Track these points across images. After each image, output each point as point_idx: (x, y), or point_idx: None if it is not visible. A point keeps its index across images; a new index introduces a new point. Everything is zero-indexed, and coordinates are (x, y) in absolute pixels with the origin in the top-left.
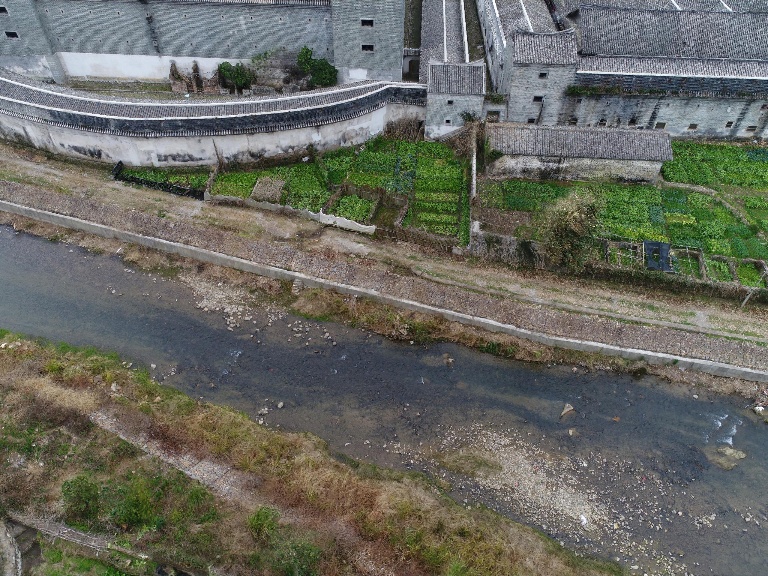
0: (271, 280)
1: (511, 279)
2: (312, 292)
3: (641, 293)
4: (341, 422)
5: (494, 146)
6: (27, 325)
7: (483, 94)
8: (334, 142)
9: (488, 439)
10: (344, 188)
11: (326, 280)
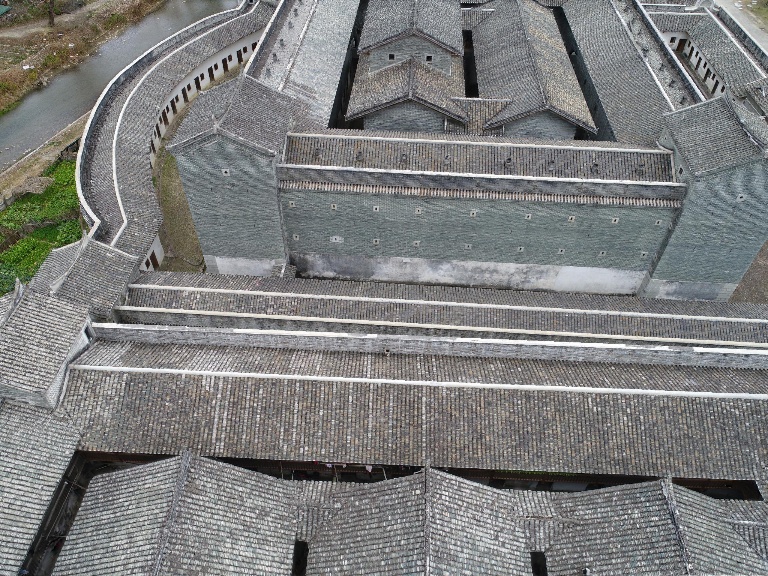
0: None
1: None
2: None
3: None
4: None
5: None
6: (1, 124)
7: None
8: None
9: None
10: None
11: None
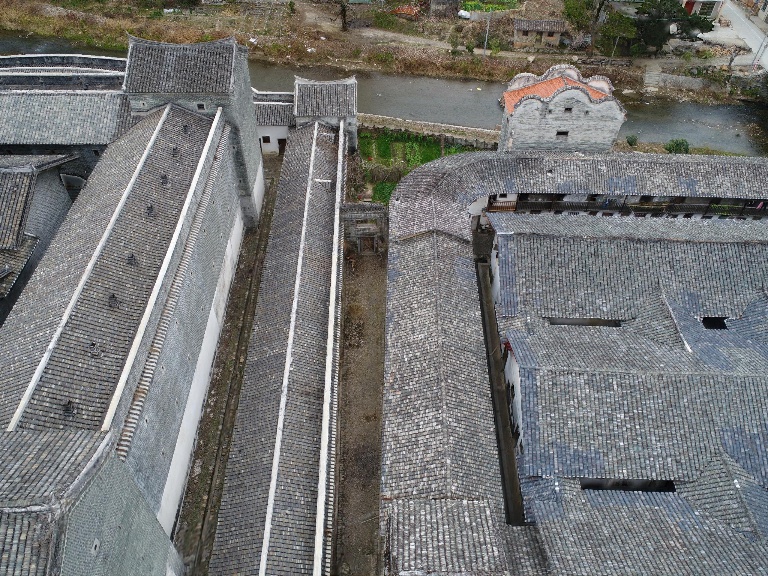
0: None
1: None
2: None
3: None
4: None
5: None
6: None
7: None
8: None
9: None
10: None
11: None
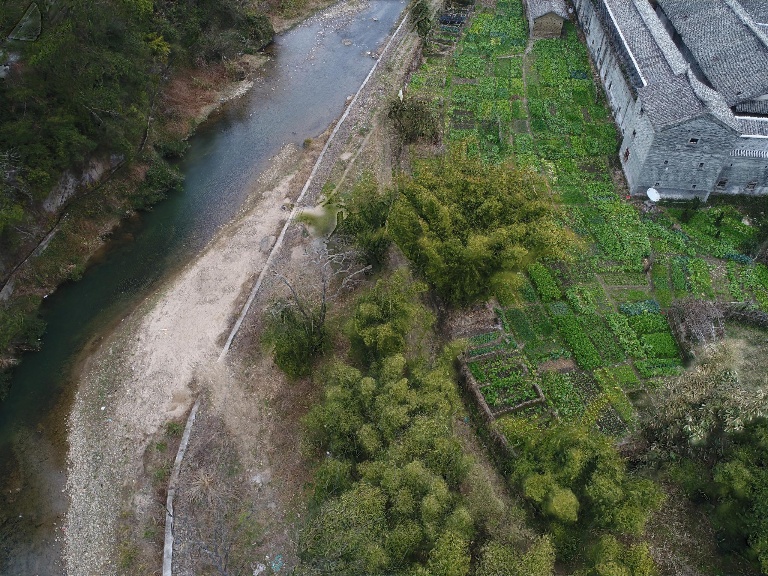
0: None
1: (441, 1)
2: None
3: None
4: None
5: None
6: None
7: None
8: None
9: (363, 5)
10: None
11: None
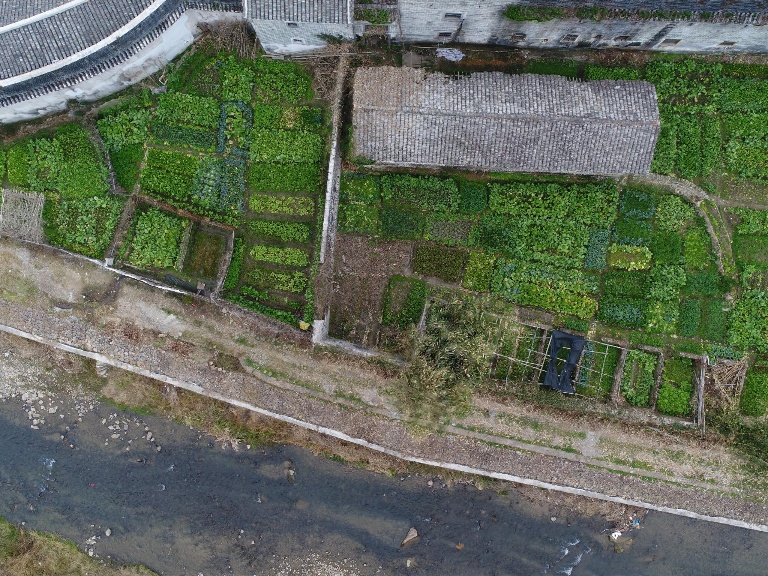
0: (68, 353)
1: (368, 380)
2: (122, 379)
3: (529, 401)
4: (173, 552)
5: (361, 147)
6: None
7: (347, 23)
8: (110, 86)
9: (323, 572)
10: (138, 200)
11: (135, 367)
